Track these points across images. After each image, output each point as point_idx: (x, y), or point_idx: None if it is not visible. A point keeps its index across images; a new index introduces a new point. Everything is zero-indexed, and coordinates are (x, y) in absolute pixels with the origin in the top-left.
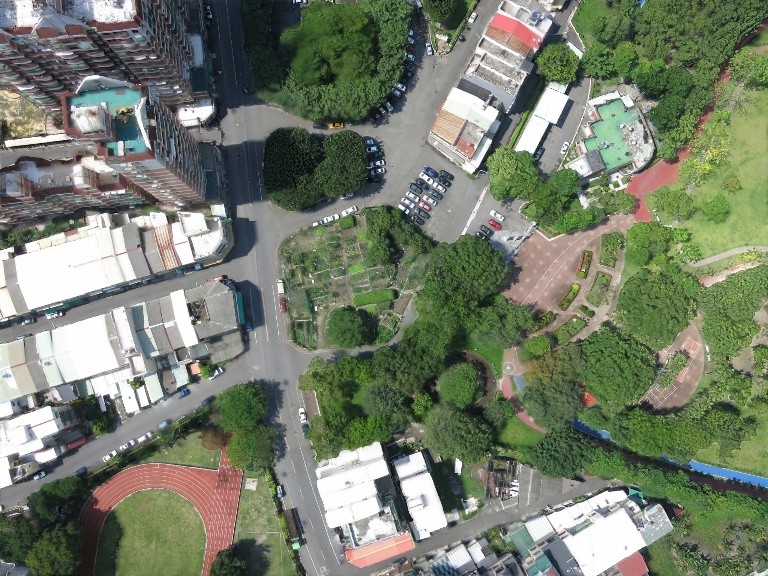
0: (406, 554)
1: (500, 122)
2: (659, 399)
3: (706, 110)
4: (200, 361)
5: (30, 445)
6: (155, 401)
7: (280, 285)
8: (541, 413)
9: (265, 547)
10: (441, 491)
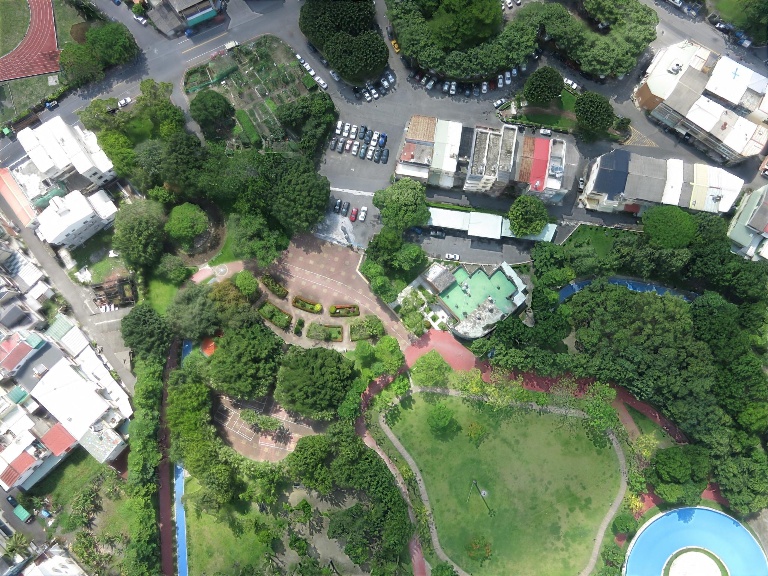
0: (24, 231)
1: (453, 186)
2: (235, 426)
3: (545, 386)
4: (147, 3)
5: None
6: None
7: (233, 44)
8: (177, 297)
9: (1, 109)
10: (89, 244)
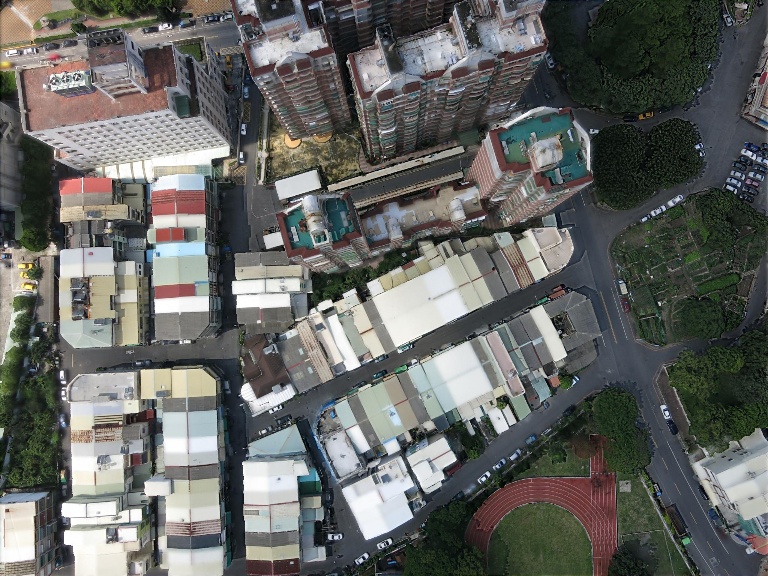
0: None
1: None
2: None
3: None
4: None
5: (432, 478)
6: (523, 418)
7: (623, 286)
8: None
9: (650, 546)
10: None
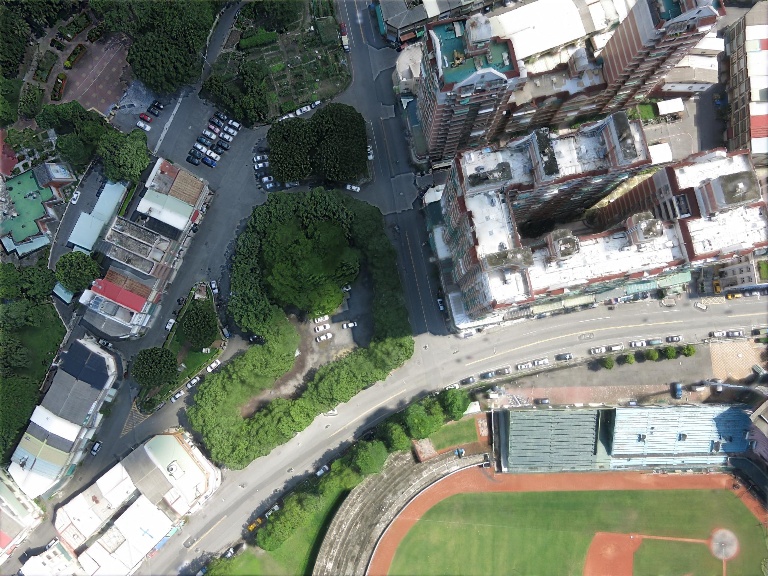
0: None
1: None
2: None
3: None
4: None
5: None
6: None
7: (346, 43)
8: None
9: None
10: None
